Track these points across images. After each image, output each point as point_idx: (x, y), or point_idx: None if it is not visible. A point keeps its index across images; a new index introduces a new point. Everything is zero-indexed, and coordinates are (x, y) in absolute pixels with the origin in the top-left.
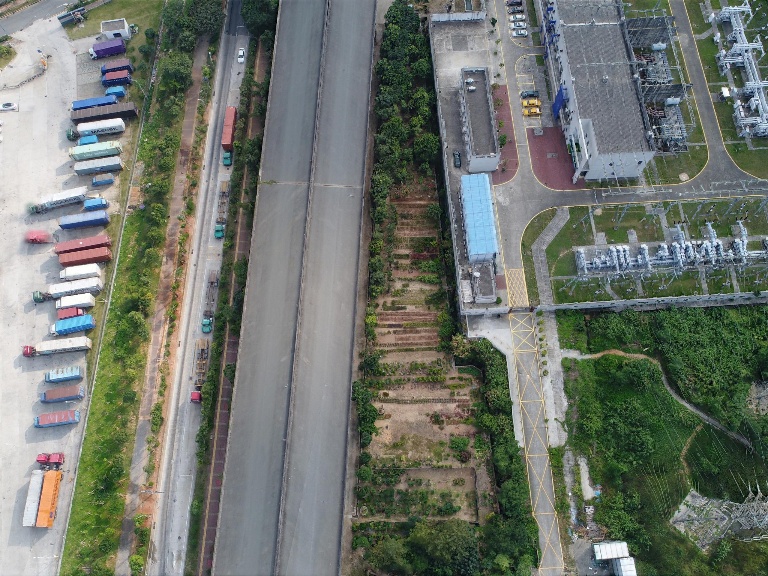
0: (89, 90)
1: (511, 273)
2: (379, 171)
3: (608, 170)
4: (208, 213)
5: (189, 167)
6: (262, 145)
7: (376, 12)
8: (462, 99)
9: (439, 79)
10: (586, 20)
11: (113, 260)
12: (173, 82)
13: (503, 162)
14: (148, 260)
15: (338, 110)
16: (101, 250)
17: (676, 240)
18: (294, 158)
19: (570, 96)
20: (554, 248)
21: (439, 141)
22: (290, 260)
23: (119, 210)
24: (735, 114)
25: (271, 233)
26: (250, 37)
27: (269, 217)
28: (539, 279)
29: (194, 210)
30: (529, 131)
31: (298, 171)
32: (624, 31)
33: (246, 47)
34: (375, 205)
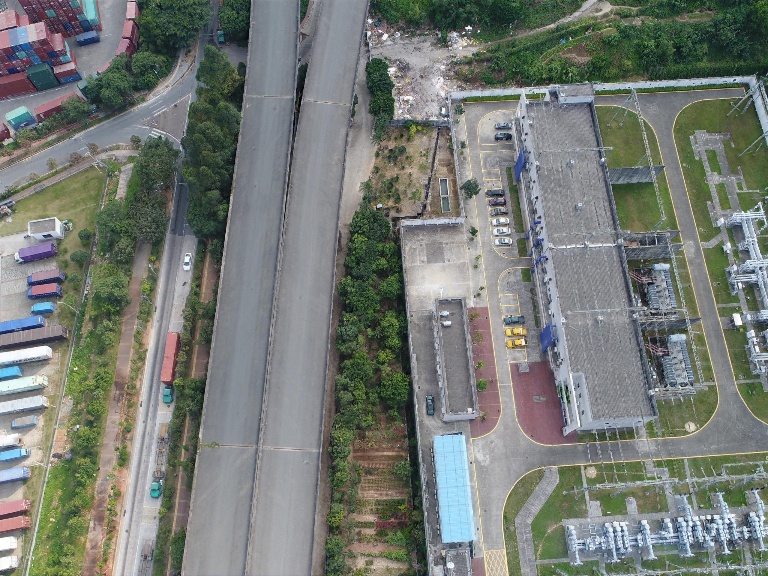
0: (14, 302)
1: (491, 555)
2: (339, 425)
3: (603, 426)
4: (144, 463)
5: (124, 404)
6: (204, 397)
7: (340, 215)
8: (436, 333)
9: (411, 300)
10: (578, 241)
11: (32, 527)
12: (106, 306)
13: (482, 414)
14: (71, 533)
15: (293, 349)
16: (16, 521)
17: (682, 511)
18: (240, 413)
19: (560, 338)
20: (541, 522)
21: (409, 383)
22: (232, 549)
23: (42, 460)
24: (748, 346)
25: (211, 513)
26: (198, 238)
27: (209, 491)
28: (523, 563)
29: (128, 460)
30: (513, 367)
31: (245, 430)
32: (622, 255)
33: (193, 250)
34: (334, 468)
